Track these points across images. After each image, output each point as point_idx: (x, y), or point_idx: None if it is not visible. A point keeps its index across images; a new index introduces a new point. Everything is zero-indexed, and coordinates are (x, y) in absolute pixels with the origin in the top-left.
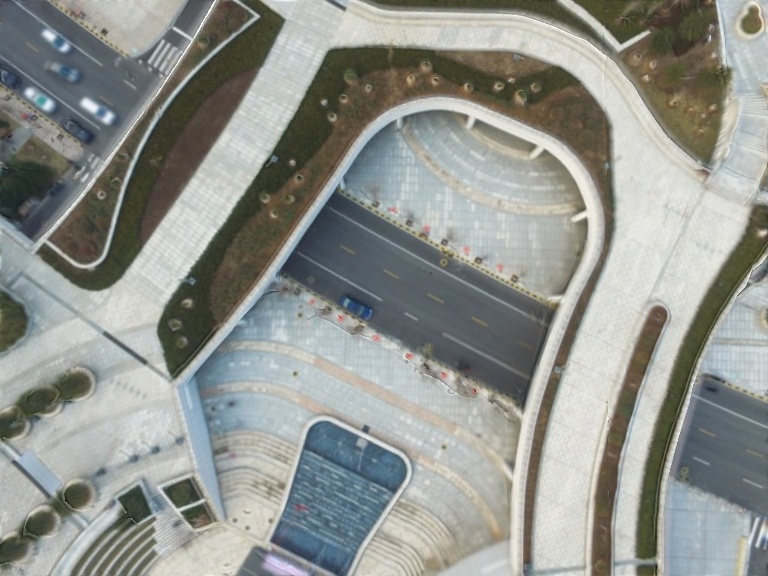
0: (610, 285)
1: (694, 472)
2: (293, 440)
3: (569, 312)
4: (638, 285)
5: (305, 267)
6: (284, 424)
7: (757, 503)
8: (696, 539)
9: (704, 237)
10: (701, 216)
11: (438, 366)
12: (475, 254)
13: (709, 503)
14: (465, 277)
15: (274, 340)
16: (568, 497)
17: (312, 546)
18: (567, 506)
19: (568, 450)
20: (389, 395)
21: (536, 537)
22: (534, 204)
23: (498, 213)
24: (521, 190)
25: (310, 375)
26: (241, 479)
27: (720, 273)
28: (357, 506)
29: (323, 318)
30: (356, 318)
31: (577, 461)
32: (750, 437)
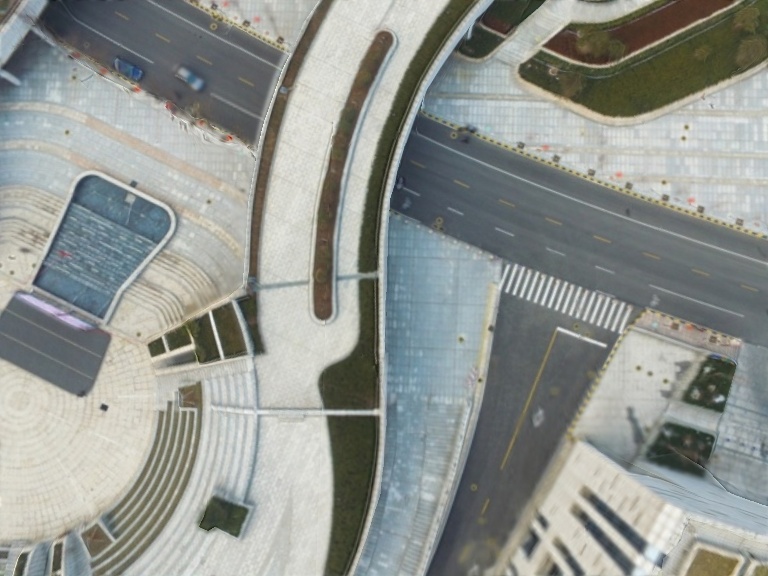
0: (341, 14)
1: (448, 222)
2: (62, 194)
3: (298, 37)
4: (369, 14)
5: (80, 32)
6: (55, 180)
7: (508, 251)
8: (448, 286)
9: None
10: None
11: None
12: (243, 18)
13: (462, 251)
14: (231, 37)
15: (48, 101)
16: (294, 215)
17: (73, 289)
18: (293, 223)
19: (295, 169)
20: (157, 152)
21: (263, 253)
22: None
23: None
24: None
25: (82, 134)
26: (8, 228)
27: (449, 4)
28: (121, 255)
29: (70, 53)
30: (128, 80)
31: (304, 180)
32: (503, 188)
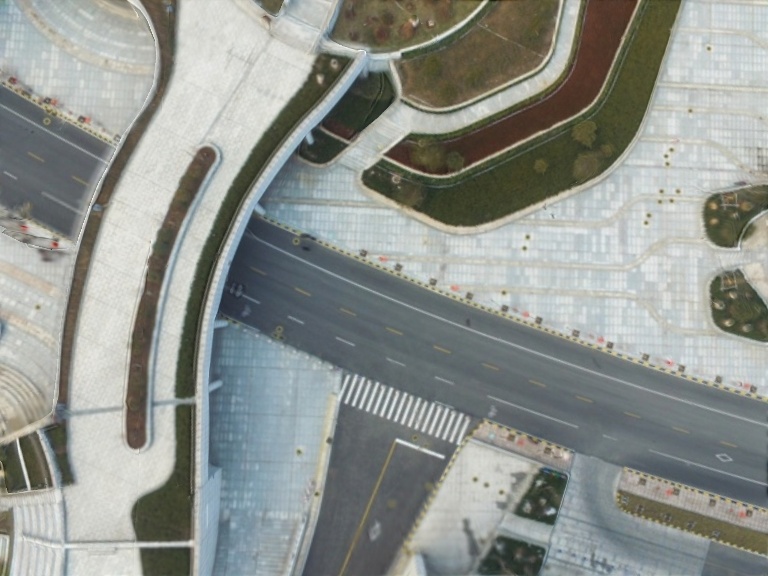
0: (163, 127)
1: (288, 331)
2: None
3: (115, 151)
4: (192, 128)
5: None
6: None
7: (349, 361)
8: (287, 397)
9: (266, 83)
10: (265, 63)
11: (33, 224)
12: (78, 113)
13: (301, 361)
14: (63, 134)
15: None
16: (109, 337)
17: None
18: (108, 346)
19: (110, 290)
20: None
21: (74, 378)
22: (141, 64)
23: (104, 72)
24: (129, 50)
25: None
26: None
27: (277, 118)
28: None
29: None
30: None
31: (119, 301)
32: (344, 296)
